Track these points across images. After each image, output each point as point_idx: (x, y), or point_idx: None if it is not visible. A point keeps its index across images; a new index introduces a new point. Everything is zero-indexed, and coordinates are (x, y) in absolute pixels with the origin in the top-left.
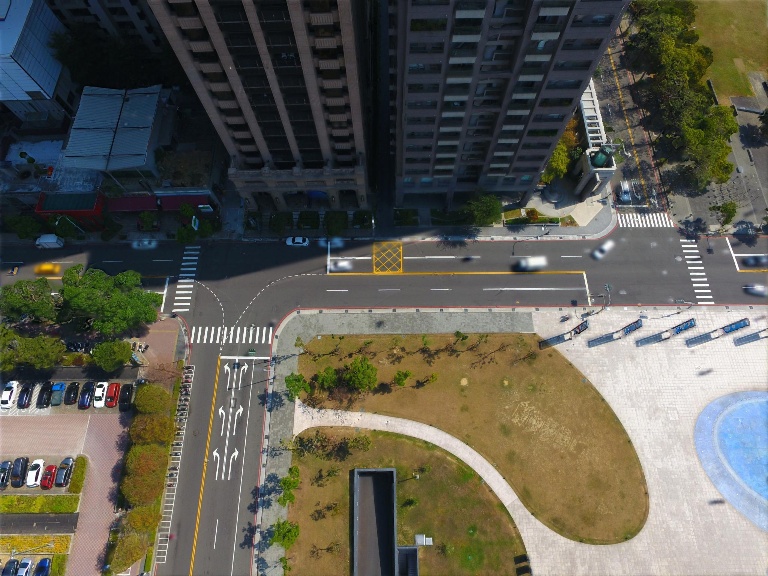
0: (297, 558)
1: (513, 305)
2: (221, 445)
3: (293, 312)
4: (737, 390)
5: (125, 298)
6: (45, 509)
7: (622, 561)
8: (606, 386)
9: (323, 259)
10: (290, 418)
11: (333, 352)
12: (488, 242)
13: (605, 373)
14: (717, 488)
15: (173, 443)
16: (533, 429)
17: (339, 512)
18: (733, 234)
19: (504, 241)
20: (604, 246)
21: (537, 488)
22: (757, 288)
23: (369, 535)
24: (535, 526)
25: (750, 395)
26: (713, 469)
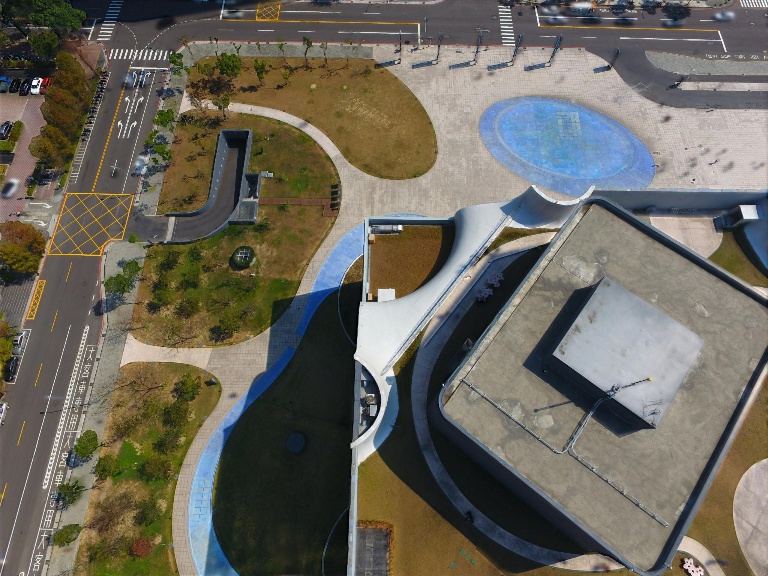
0: (172, 182)
1: (360, 42)
2: (124, 118)
3: (190, 42)
4: (519, 96)
5: (55, 6)
6: None
7: (409, 189)
8: (420, 91)
9: (218, 11)
10: (178, 103)
11: (217, 66)
12: (348, 4)
13: (421, 84)
14: (489, 151)
15: (88, 115)
16: (360, 114)
17: (207, 157)
18: (541, 4)
19: (361, 3)
20: (438, 8)
21: (356, 147)
22: (551, 37)
23: (229, 178)
24: (350, 169)
25: (528, 99)
26: (489, 140)
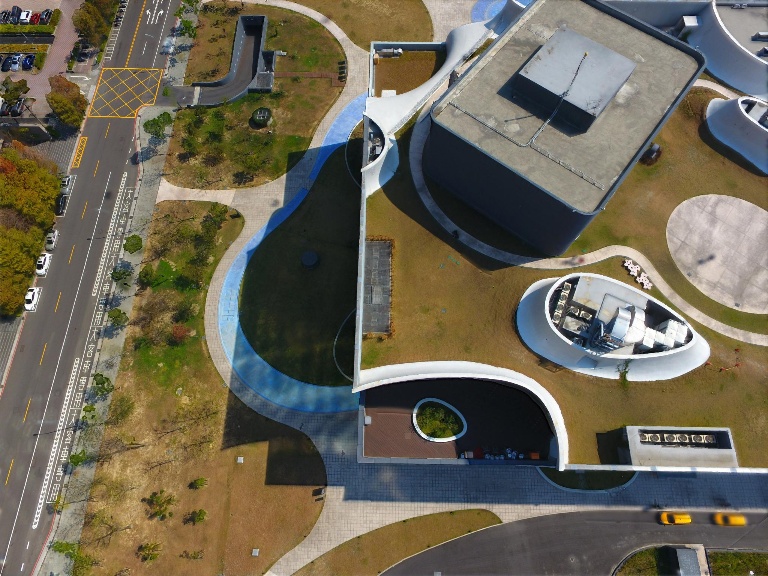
0: (196, 59)
1: None
2: (152, 8)
3: None
4: None
5: None
6: (32, 30)
7: None
8: None
9: None
10: None
11: None
12: None
13: None
14: None
15: (120, 5)
16: (364, 5)
17: (227, 39)
18: None
19: None
20: None
21: (360, 32)
22: None
23: (247, 59)
24: (355, 49)
25: None
26: None
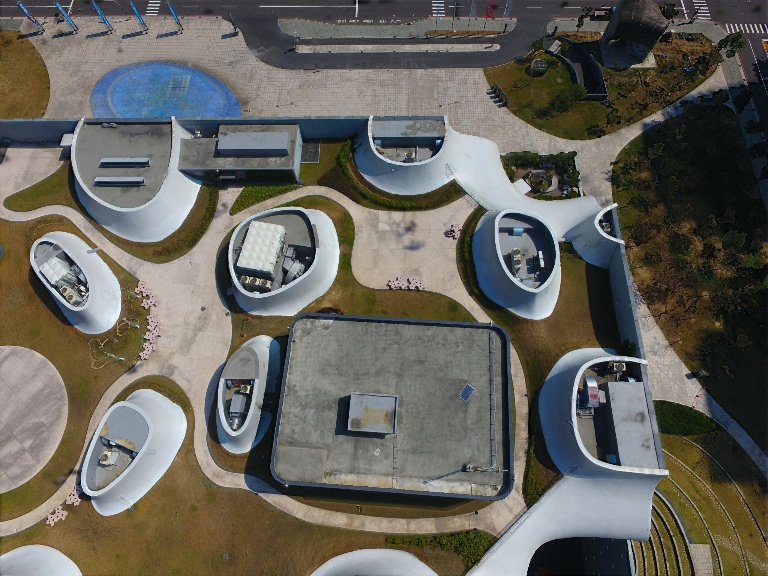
0: None
1: (13, 15)
2: None
3: None
4: (141, 61)
5: None
6: None
7: None
8: (51, 59)
9: None
10: None
11: None
12: None
13: (55, 52)
14: (93, 111)
15: None
16: None
17: None
18: None
19: None
20: None
21: None
22: (194, 7)
23: None
24: None
25: (149, 64)
26: (97, 102)
